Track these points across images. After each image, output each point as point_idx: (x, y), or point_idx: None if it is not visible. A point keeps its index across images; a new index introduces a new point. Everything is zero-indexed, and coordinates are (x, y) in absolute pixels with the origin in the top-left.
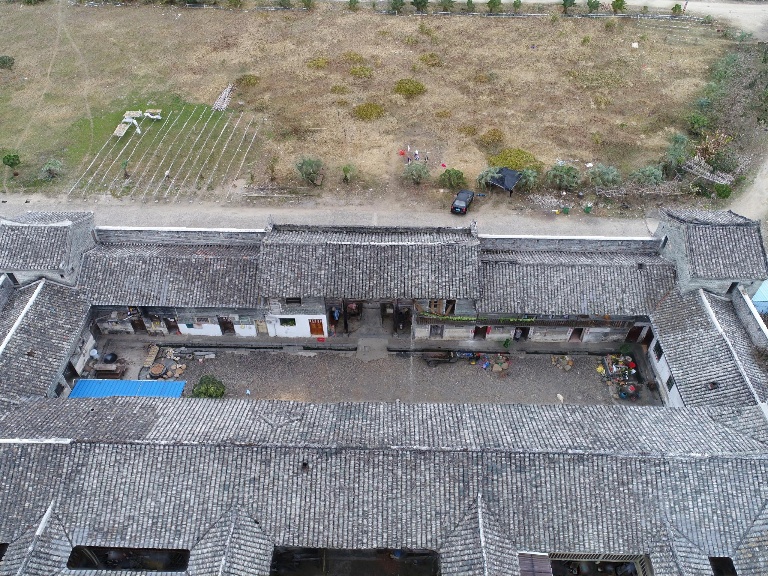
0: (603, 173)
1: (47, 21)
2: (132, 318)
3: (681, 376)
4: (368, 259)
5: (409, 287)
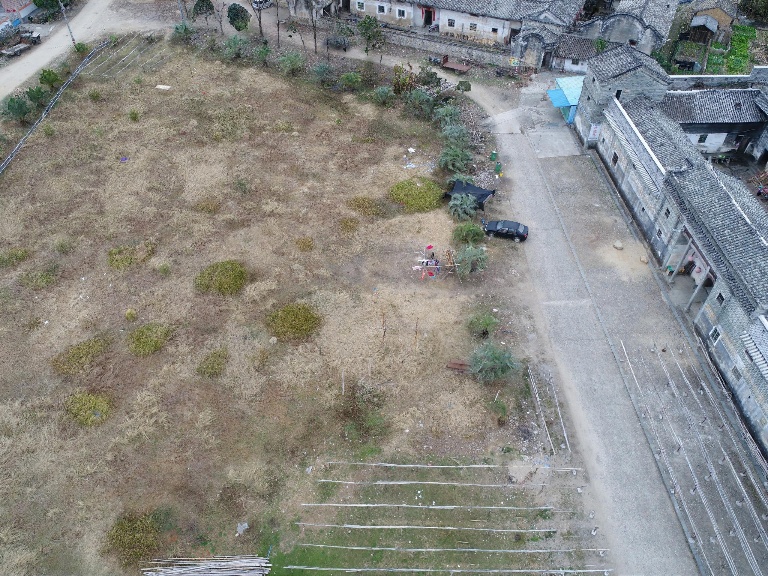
0: (460, 132)
1: None
2: None
3: (730, 118)
4: (762, 232)
5: (763, 215)
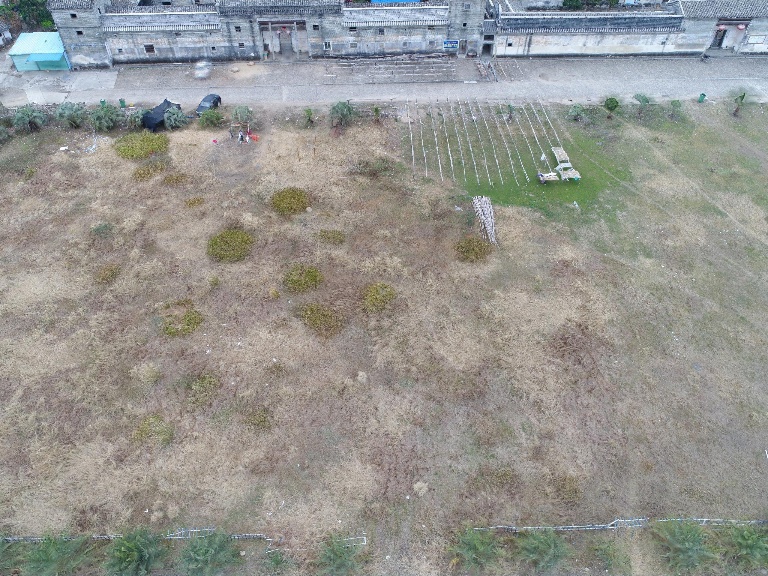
0: (73, 106)
1: None
2: None
3: None
4: None
5: None
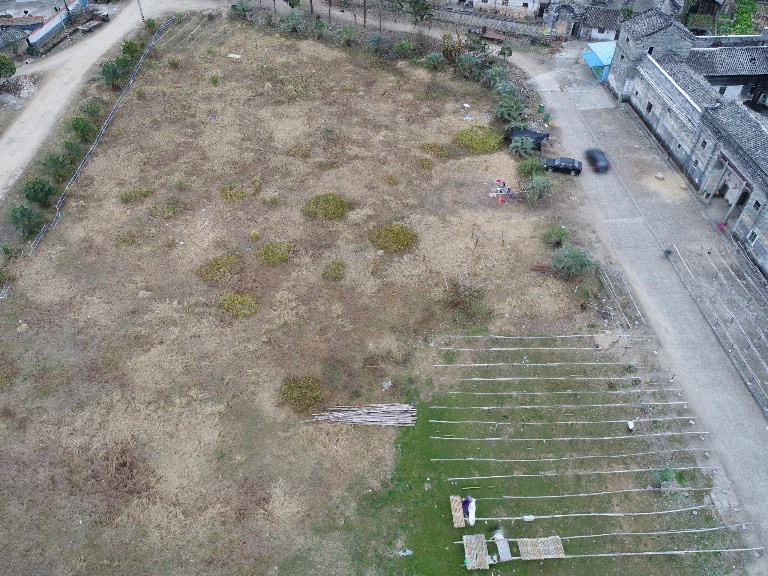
0: (511, 88)
1: None
2: None
3: (746, 71)
4: None
5: None
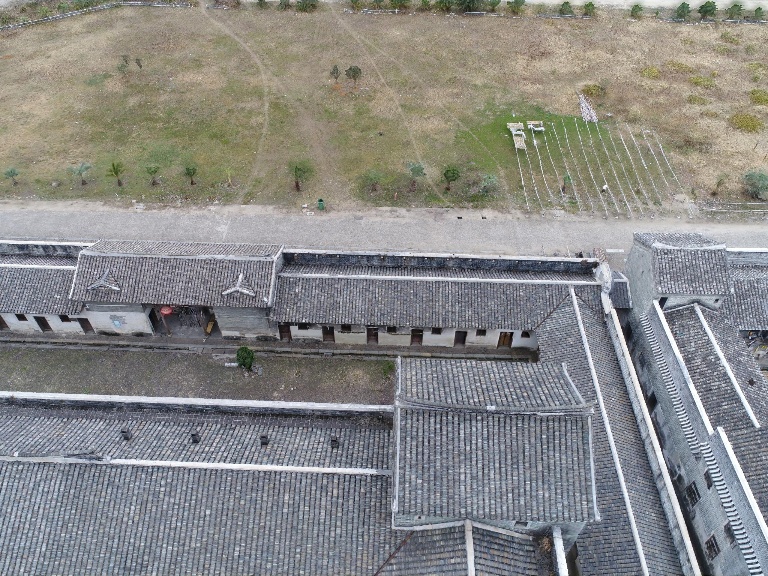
0: None
1: (336, 29)
2: (756, 342)
3: None
4: None
5: None
